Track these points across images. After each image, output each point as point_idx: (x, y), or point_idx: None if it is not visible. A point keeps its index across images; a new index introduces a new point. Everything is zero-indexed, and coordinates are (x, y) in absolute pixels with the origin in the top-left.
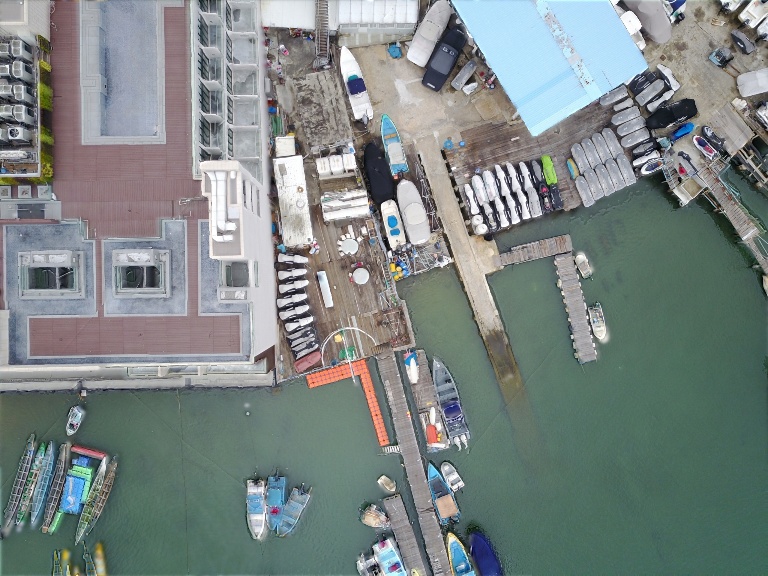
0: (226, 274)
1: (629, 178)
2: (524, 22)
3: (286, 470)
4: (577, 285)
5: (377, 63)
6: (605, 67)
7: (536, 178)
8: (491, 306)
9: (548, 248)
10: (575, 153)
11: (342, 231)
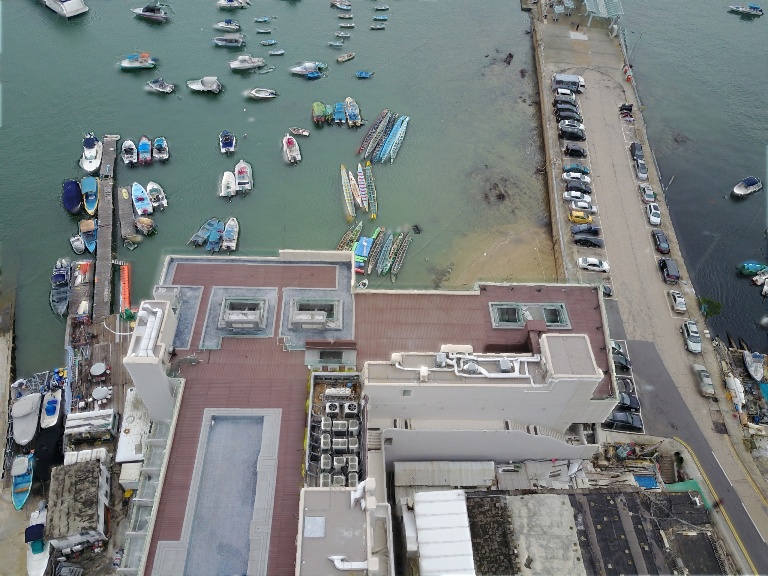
0: None
1: None
2: None
3: None
4: None
5: None
6: None
7: None
8: None
9: None
10: None
11: (105, 408)
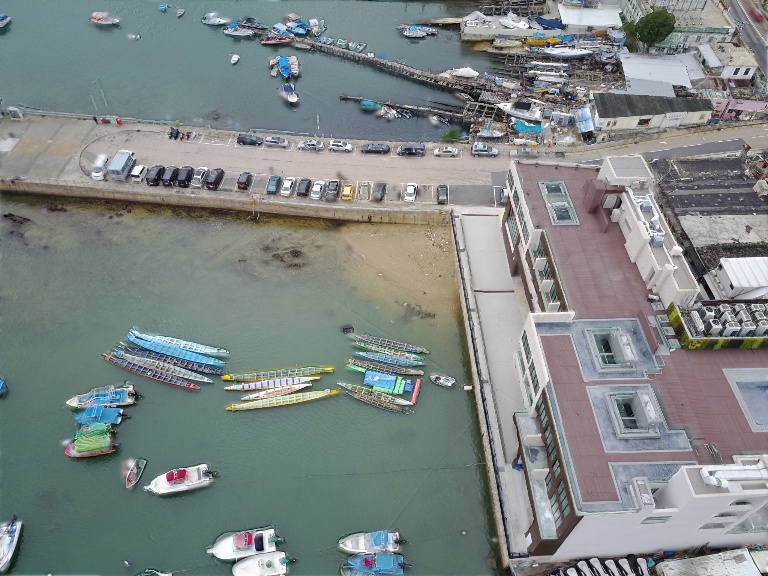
0: (651, 489)
1: None
2: None
3: (410, 575)
4: None
5: None
6: None
7: None
8: None
9: None
10: None
11: None
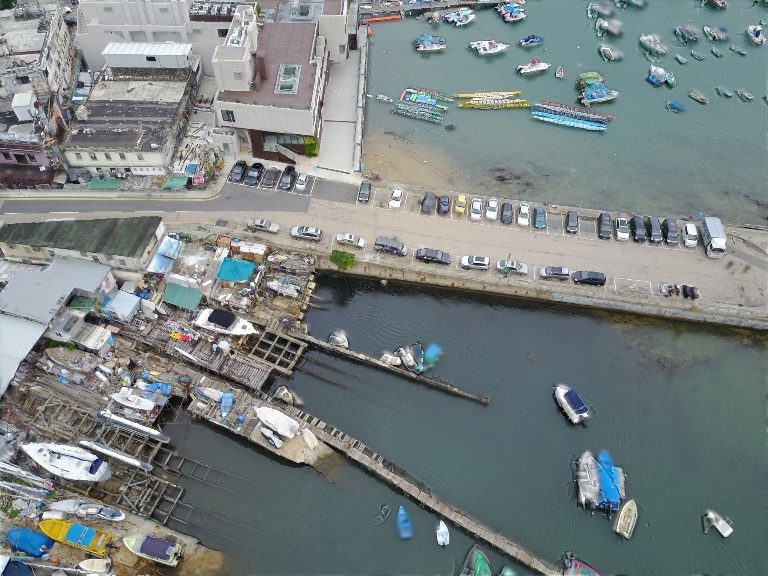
0: None
1: None
2: None
3: None
4: None
5: None
6: None
7: None
8: None
9: None
10: None
11: None
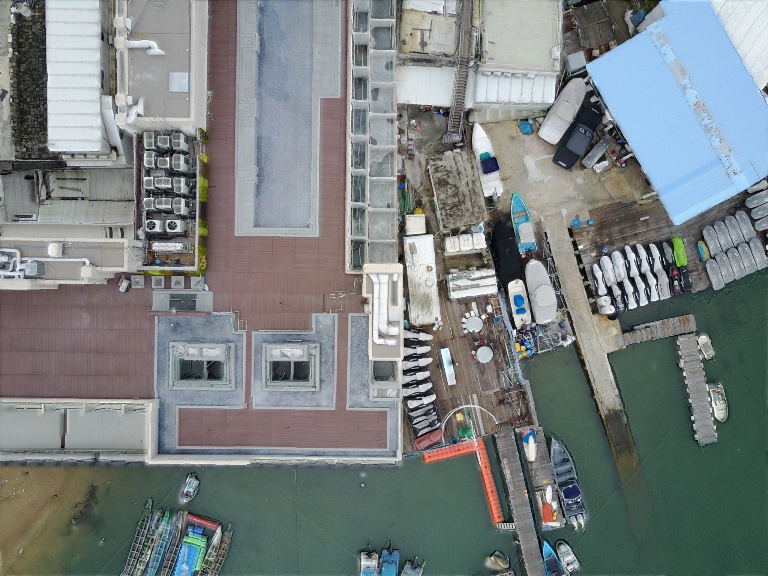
0: (373, 367)
1: (762, 263)
2: (671, 110)
3: (400, 543)
4: (699, 366)
5: (506, 139)
6: (753, 157)
7: (666, 260)
8: (612, 385)
9: (671, 328)
10: (707, 236)
11: (466, 308)
